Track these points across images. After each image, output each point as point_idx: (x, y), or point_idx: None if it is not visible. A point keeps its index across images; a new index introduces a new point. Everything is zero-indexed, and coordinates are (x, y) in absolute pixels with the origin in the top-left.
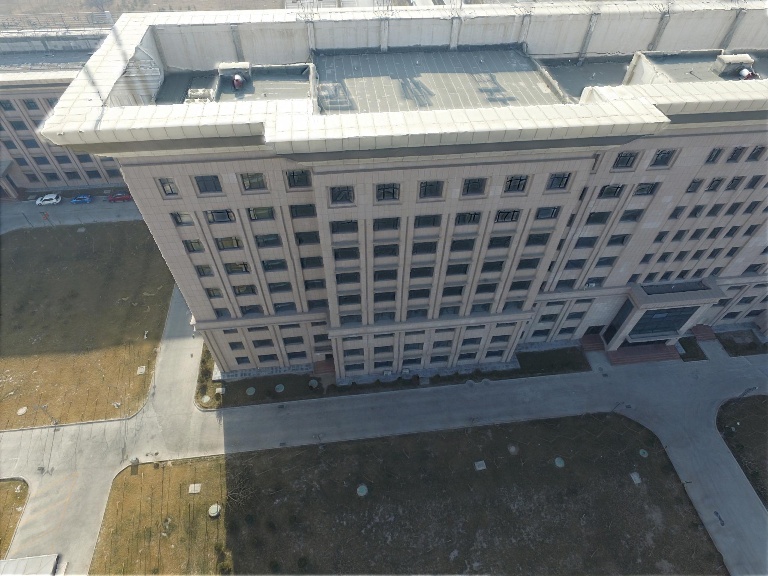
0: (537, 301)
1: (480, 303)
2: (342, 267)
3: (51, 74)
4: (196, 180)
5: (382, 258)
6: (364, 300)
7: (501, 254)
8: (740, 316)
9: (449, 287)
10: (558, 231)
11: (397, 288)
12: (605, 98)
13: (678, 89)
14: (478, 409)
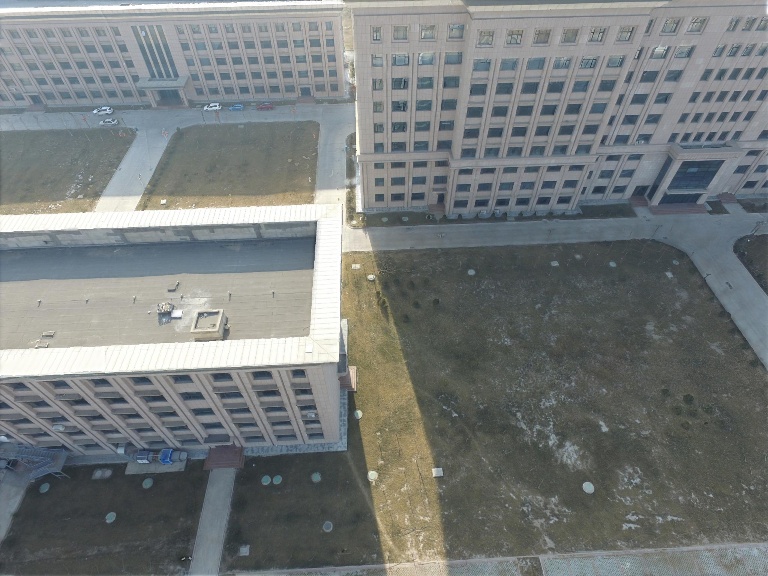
0: (599, 154)
1: (560, 144)
2: (473, 101)
3: (233, 4)
4: (394, 29)
5: (500, 95)
6: (481, 134)
7: (580, 98)
8: (758, 186)
9: (540, 127)
10: (621, 78)
11: (505, 124)
12: None
13: None
14: (551, 235)
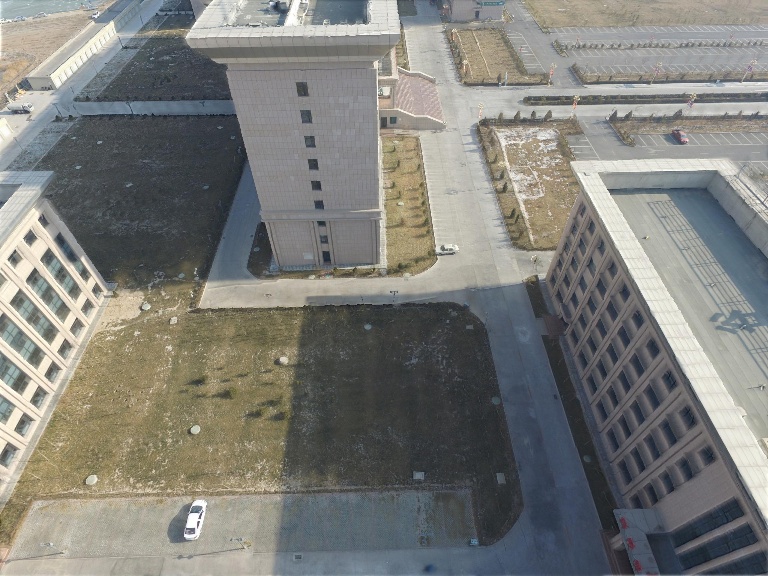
0: None
1: None
2: None
3: None
4: None
5: None
6: None
7: None
8: None
9: None
10: None
11: None
12: None
13: None
14: None
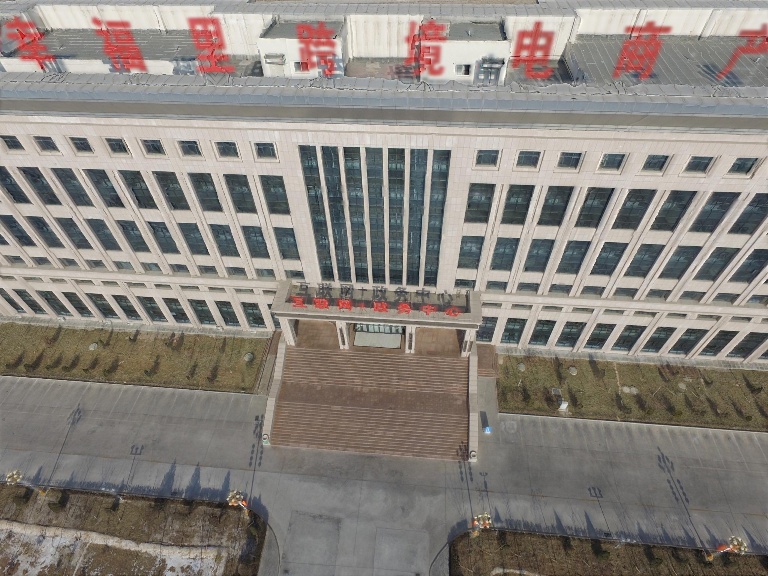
0: None
1: None
2: None
3: None
4: None
5: None
6: None
7: None
8: None
9: None
10: None
11: None
12: (572, 8)
13: (510, 11)
14: None
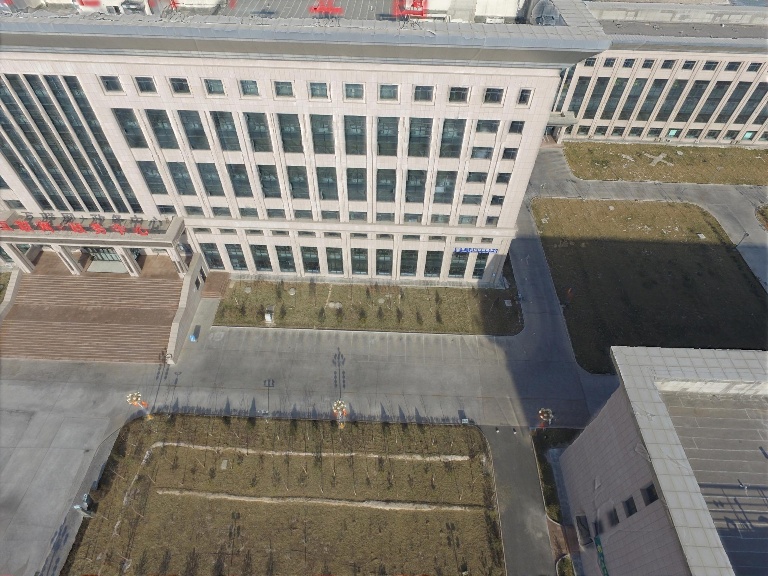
0: None
1: None
2: None
3: None
4: None
5: None
6: None
7: None
8: None
9: None
10: None
11: None
12: None
13: None
14: None
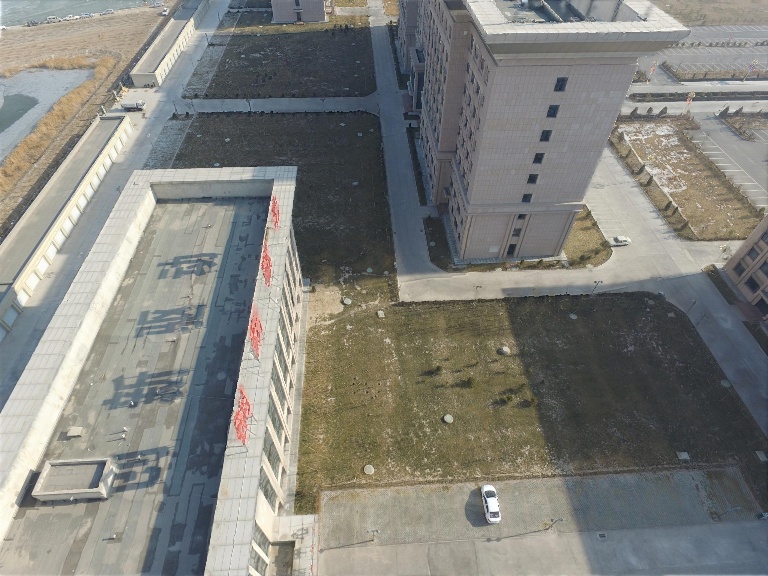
0: None
1: None
2: None
3: None
4: None
5: None
6: None
7: None
8: None
9: None
10: None
11: None
12: None
13: None
14: (382, 64)
